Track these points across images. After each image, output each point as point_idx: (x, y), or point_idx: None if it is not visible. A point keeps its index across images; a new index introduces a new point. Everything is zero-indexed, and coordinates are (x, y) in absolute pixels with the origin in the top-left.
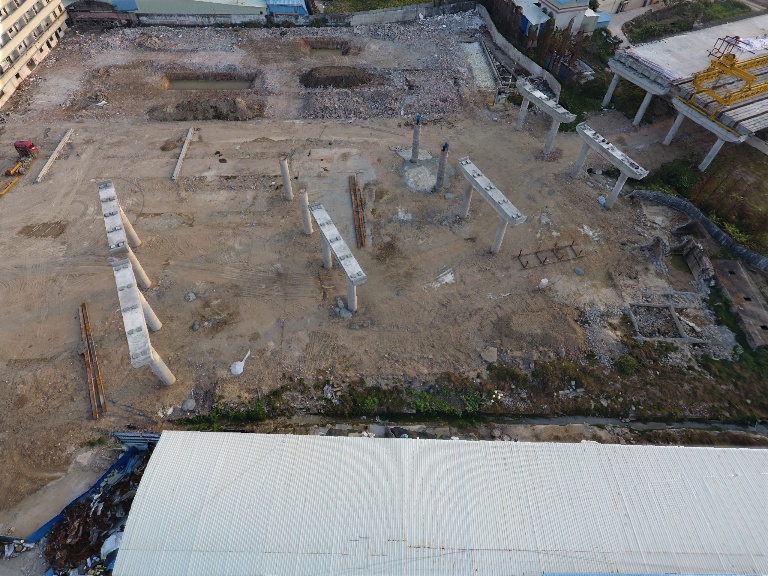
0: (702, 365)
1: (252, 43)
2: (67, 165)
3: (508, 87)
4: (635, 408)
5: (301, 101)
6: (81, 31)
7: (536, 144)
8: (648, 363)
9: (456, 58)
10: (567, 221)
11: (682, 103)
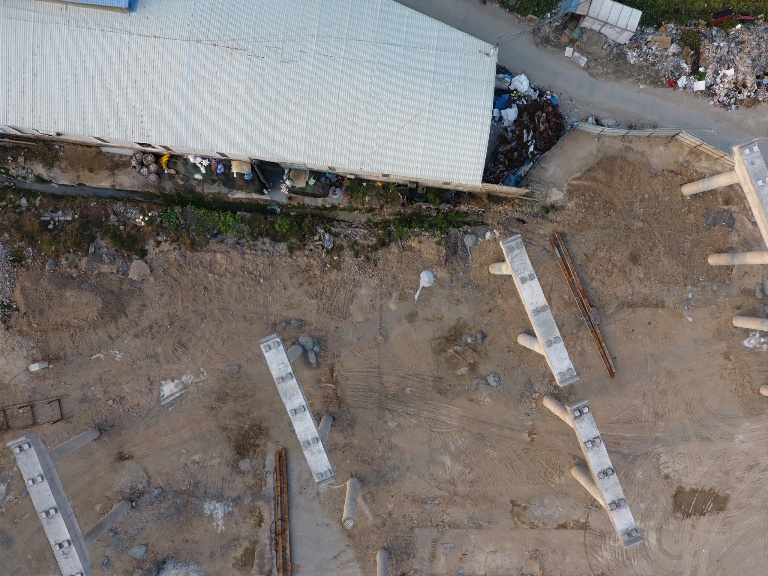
0: None
1: None
2: None
3: None
4: None
5: None
6: None
7: None
8: None
9: None
10: None
11: None
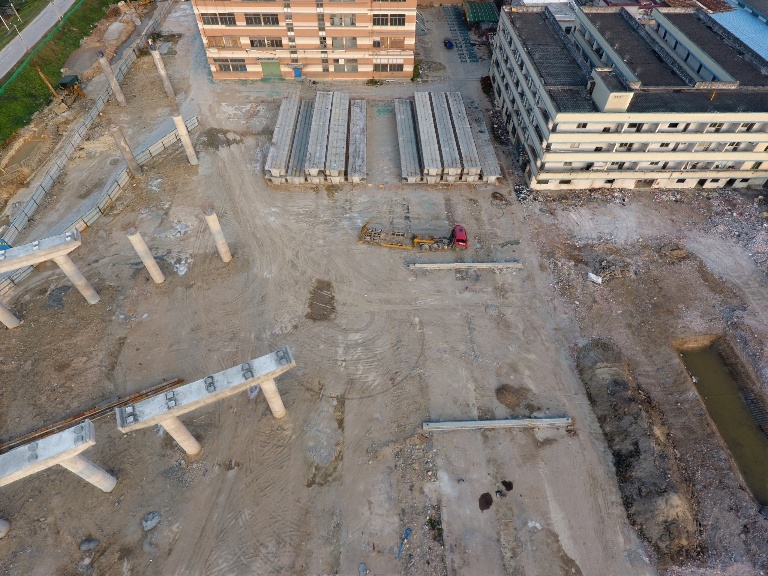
0: None
1: None
2: (445, 284)
3: None
4: None
5: None
6: (767, 200)
7: None
8: None
9: None
10: None
11: None
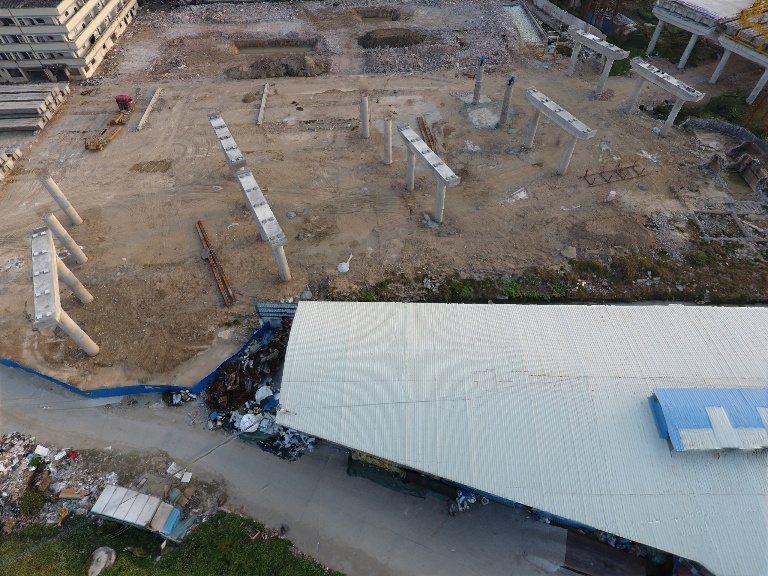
0: (767, 258)
1: (308, 14)
2: (162, 116)
3: (557, 37)
4: (709, 291)
5: (362, 59)
6: (151, 10)
7: (588, 87)
8: (717, 257)
9: (501, 19)
10: (626, 148)
11: (729, 40)
